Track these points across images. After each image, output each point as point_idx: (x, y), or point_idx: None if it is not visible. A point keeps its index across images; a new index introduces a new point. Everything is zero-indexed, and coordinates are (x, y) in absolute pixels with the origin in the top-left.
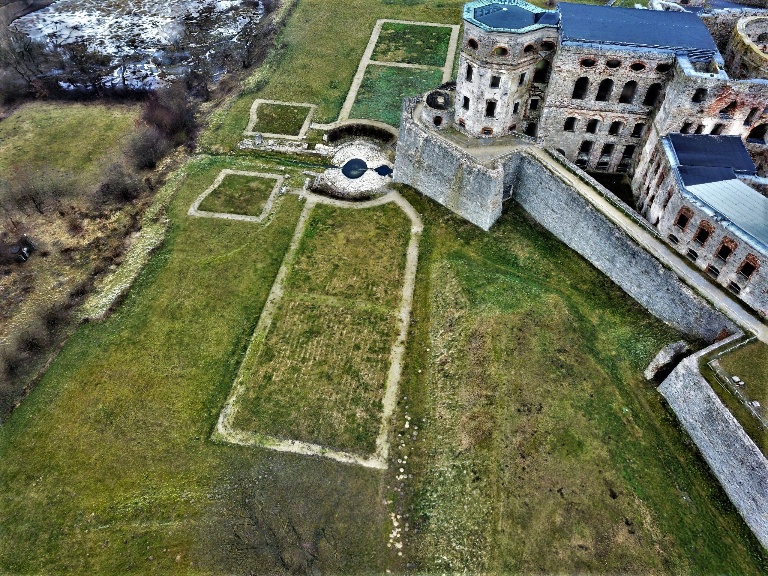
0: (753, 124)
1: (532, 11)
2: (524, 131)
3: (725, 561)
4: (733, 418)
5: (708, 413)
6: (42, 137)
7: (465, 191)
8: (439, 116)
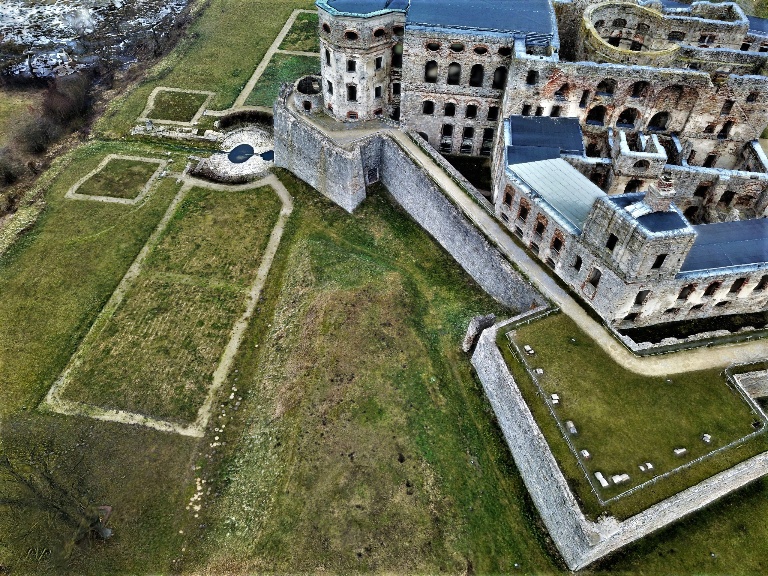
0: (589, 106)
1: None
2: (391, 115)
3: (497, 520)
4: (515, 384)
5: (499, 381)
6: None
7: (329, 174)
8: (307, 100)
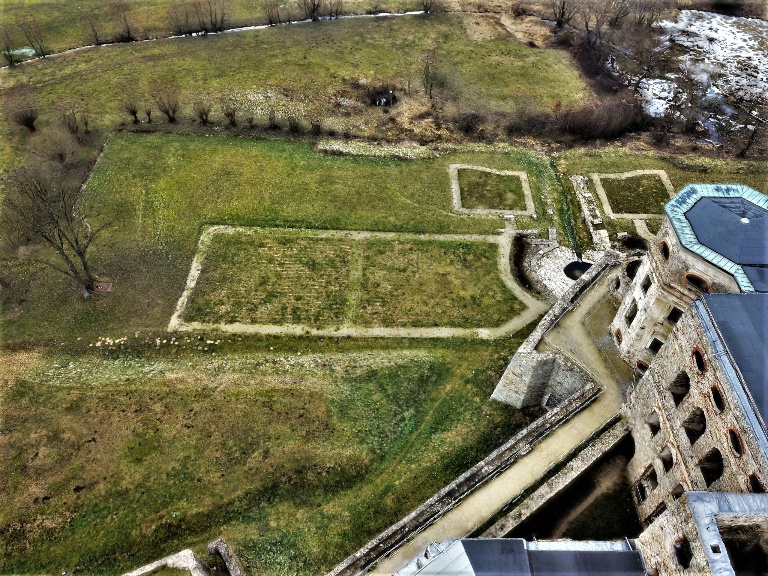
0: None
1: None
2: None
3: None
4: None
5: None
6: (520, 69)
7: None
8: None
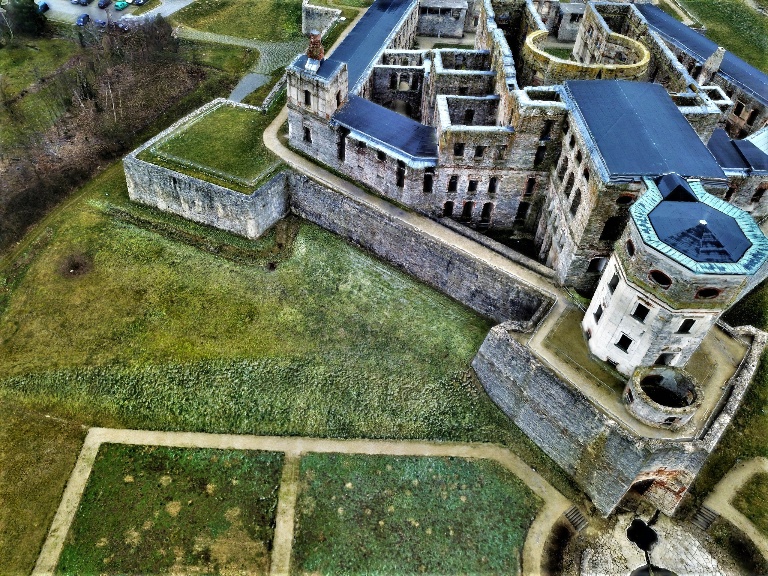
0: None
1: (658, 201)
2: None
3: None
4: None
5: None
6: None
7: None
8: None
